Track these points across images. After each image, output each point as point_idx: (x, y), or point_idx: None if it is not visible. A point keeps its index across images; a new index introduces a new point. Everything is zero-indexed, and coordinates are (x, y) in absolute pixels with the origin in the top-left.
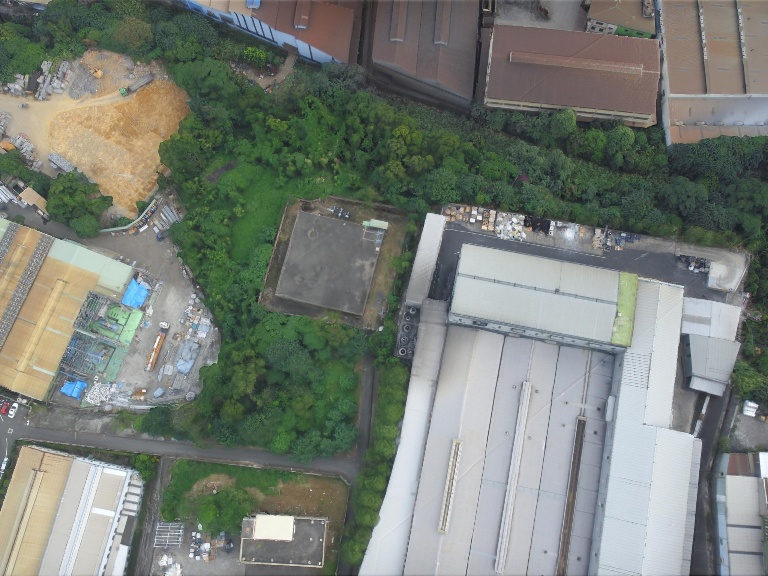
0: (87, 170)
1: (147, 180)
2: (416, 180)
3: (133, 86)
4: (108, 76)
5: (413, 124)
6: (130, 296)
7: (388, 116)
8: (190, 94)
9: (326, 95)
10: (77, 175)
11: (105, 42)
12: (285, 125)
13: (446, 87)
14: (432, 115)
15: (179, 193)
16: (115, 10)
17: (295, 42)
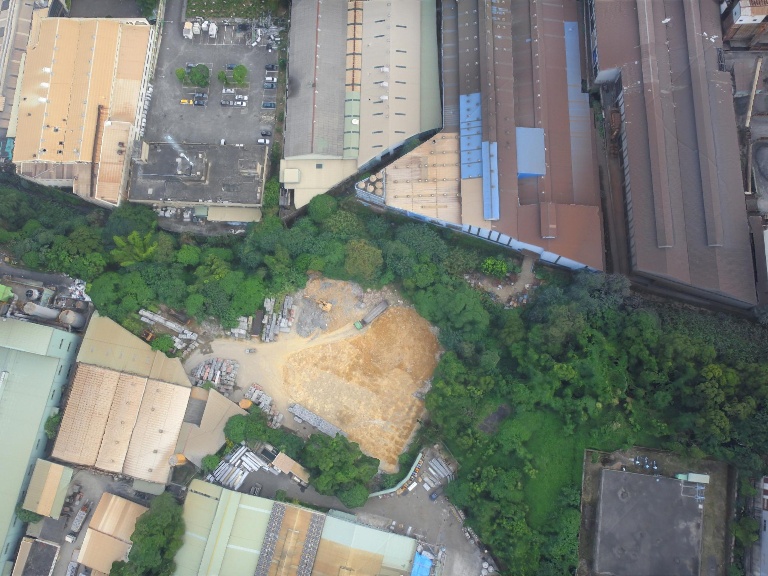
0: (333, 419)
1: (401, 425)
2: (735, 424)
3: (368, 318)
4: (336, 307)
5: (715, 354)
6: (414, 570)
7: (690, 352)
8: (437, 325)
9: (595, 317)
10: (341, 443)
11: (331, 272)
12: (573, 371)
13: (728, 295)
14: (711, 324)
15: (447, 444)
16: (328, 228)
17: (540, 251)
